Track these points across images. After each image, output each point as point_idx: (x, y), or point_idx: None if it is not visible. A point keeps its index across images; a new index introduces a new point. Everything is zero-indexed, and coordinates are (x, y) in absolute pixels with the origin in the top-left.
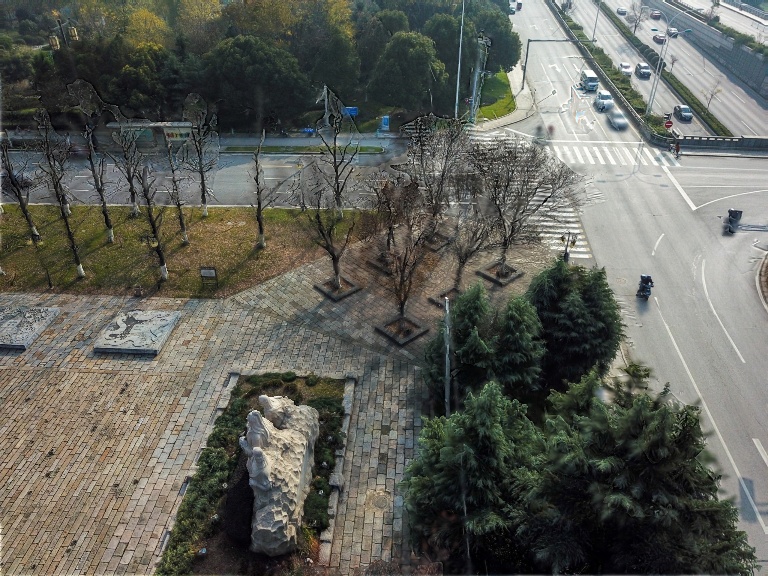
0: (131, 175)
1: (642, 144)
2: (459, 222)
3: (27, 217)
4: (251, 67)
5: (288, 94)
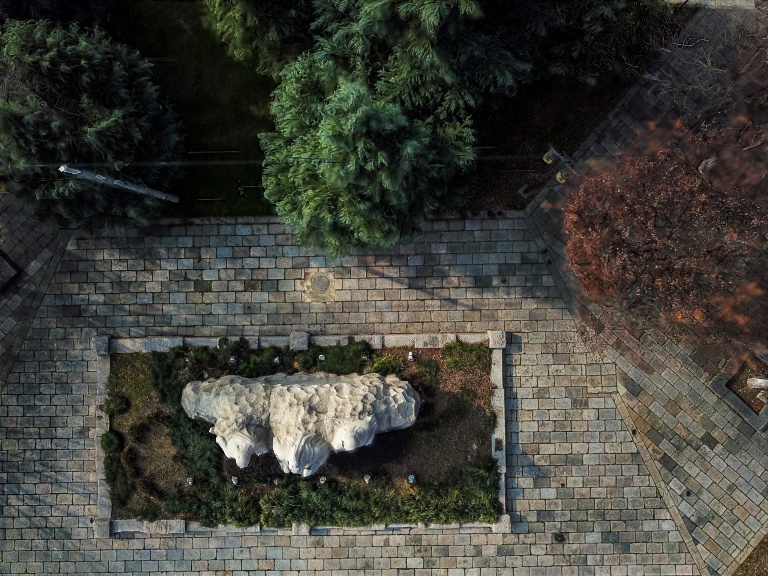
0: None
1: None
2: None
3: None
4: None
5: None
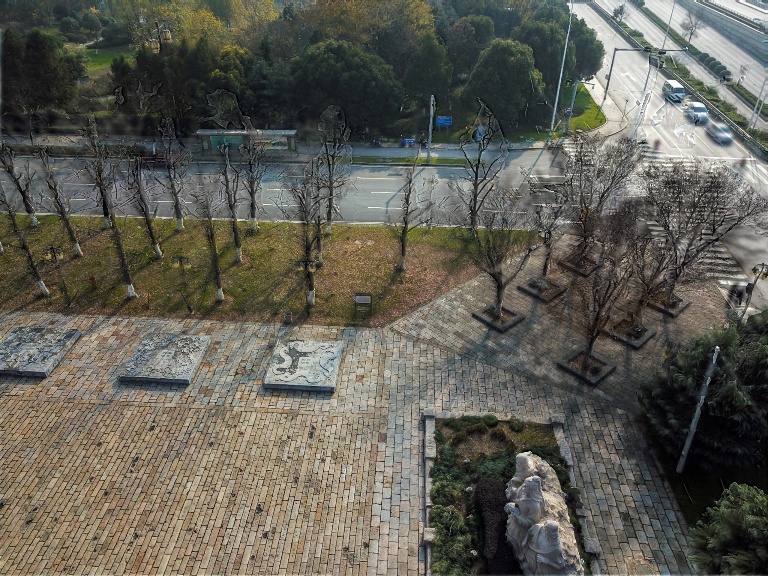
0: (254, 189)
1: (753, 161)
2: (645, 251)
3: (152, 234)
4: (347, 74)
5: (383, 102)
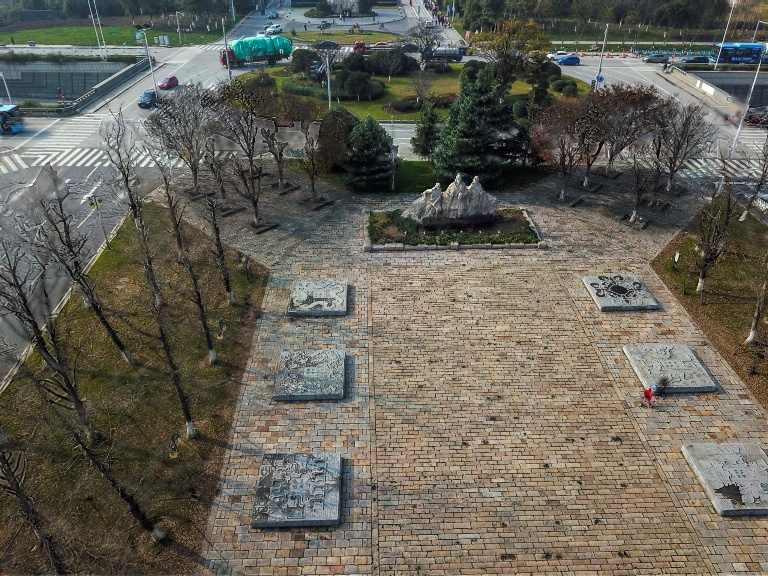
0: None
1: (62, 120)
2: None
3: (85, 411)
4: None
5: None
